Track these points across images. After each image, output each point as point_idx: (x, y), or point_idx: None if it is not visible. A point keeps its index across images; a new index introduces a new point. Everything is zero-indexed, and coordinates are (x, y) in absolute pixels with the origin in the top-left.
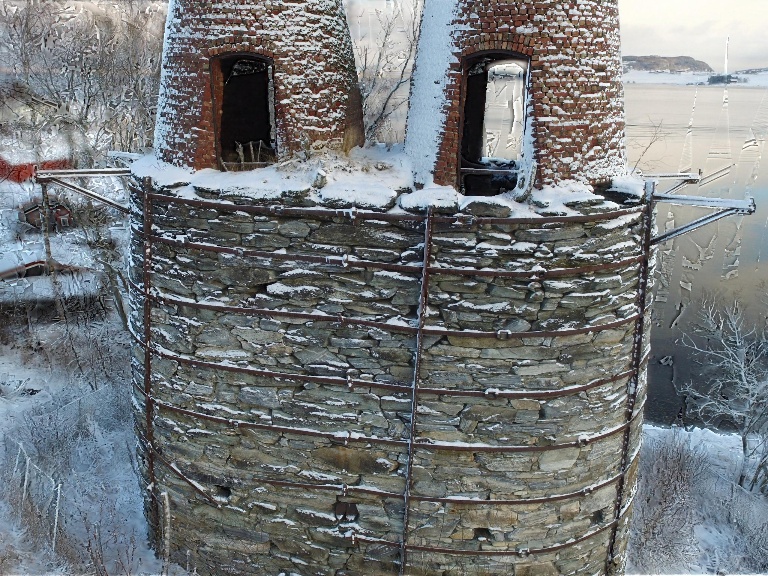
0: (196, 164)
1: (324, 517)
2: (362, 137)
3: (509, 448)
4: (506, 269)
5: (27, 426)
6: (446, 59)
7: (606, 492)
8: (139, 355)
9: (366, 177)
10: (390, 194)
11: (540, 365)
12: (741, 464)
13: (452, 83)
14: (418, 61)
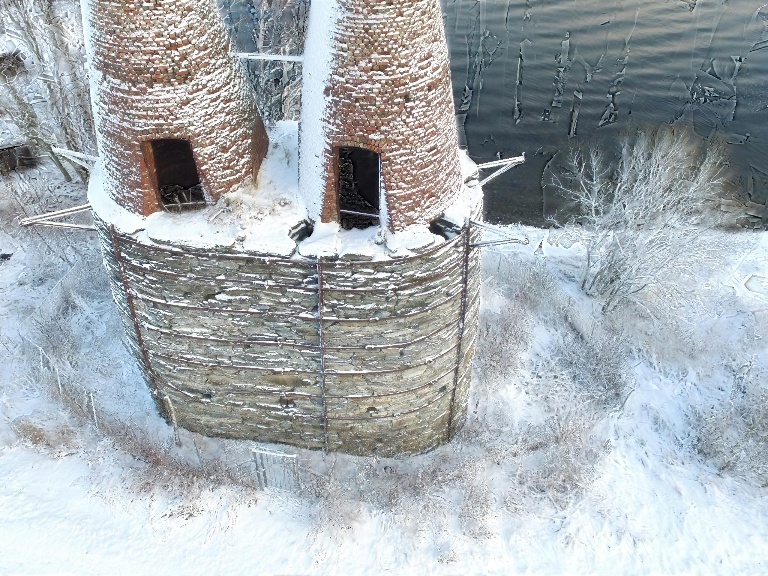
0: (145, 213)
1: (274, 407)
2: (266, 144)
3: (383, 372)
4: (372, 287)
5: (37, 328)
6: (322, 144)
7: (447, 376)
8: (129, 322)
9: (273, 222)
10: (291, 248)
11: (398, 332)
12: (586, 271)
13: (327, 162)
14: (302, 128)
